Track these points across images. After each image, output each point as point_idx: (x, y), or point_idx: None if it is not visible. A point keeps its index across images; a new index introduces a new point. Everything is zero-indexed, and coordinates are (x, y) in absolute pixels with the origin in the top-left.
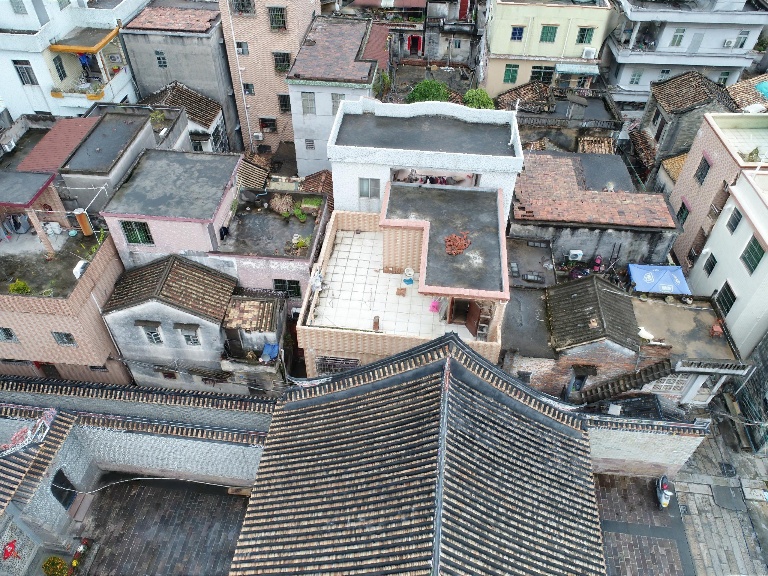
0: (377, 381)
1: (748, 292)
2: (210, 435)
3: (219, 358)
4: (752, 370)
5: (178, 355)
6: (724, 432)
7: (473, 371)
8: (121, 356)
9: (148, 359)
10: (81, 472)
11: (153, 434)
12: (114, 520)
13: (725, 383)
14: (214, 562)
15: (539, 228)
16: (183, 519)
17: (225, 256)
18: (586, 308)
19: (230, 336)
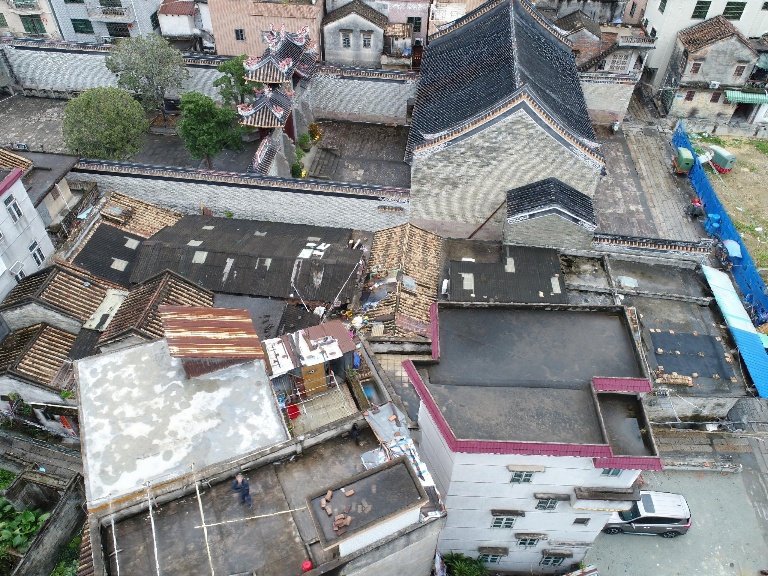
0: (477, 18)
1: (661, 23)
2: (385, 76)
3: (379, 58)
4: (666, 76)
5: (356, 57)
6: (652, 112)
7: (523, 5)
8: (324, 60)
9: (339, 62)
10: None
11: (354, 78)
12: (329, 132)
13: (655, 95)
14: (385, 144)
15: (550, 1)
16: (364, 133)
17: (384, 0)
18: (575, 22)
19: (386, 44)
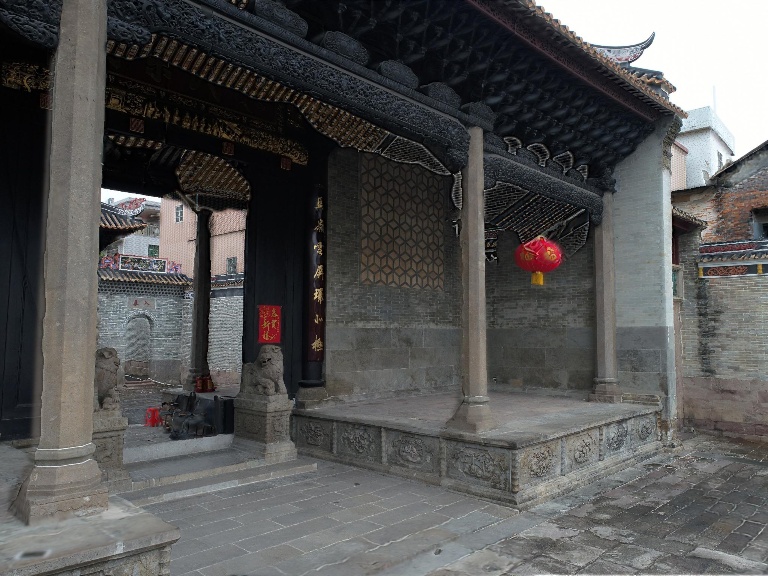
0: None
1: None
2: None
3: None
4: None
5: None
6: None
7: None
8: None
9: None
10: (163, 354)
11: (226, 293)
12: None
13: None
14: None
15: None
16: None
17: None
18: None
19: None
